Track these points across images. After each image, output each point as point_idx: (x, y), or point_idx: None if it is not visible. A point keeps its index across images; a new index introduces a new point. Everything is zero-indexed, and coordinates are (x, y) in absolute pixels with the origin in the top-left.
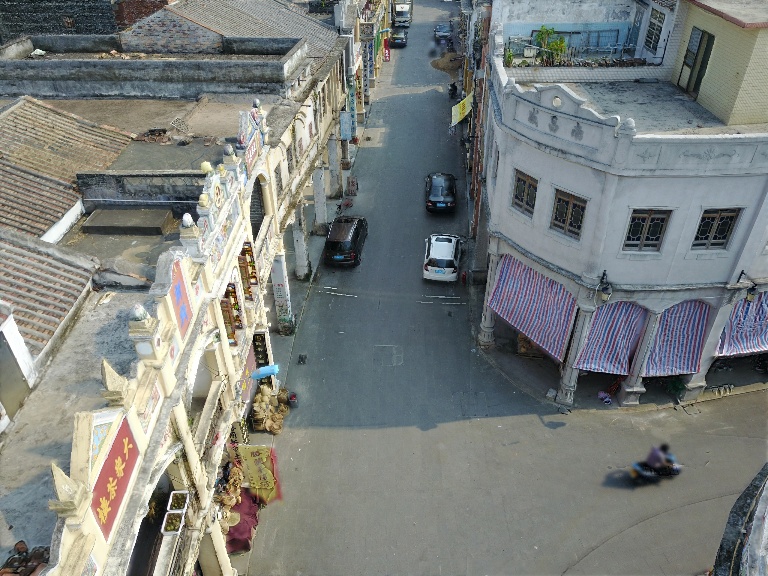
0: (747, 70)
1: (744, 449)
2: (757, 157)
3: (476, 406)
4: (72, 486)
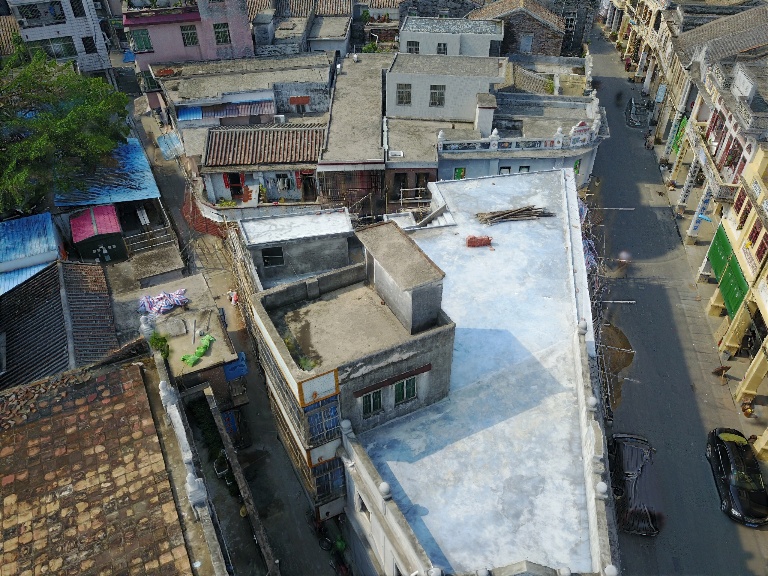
0: None
1: None
2: None
3: None
4: None
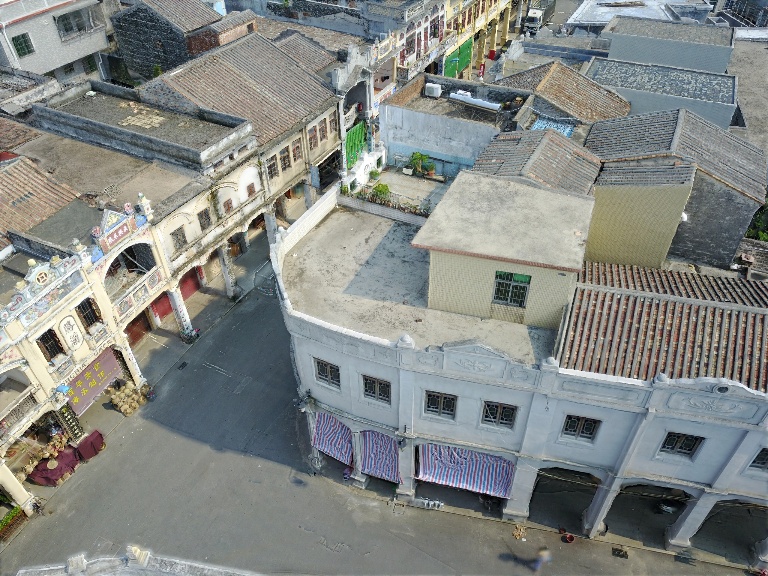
0: (431, 274)
1: (404, 555)
2: (377, 353)
3: (258, 445)
4: None
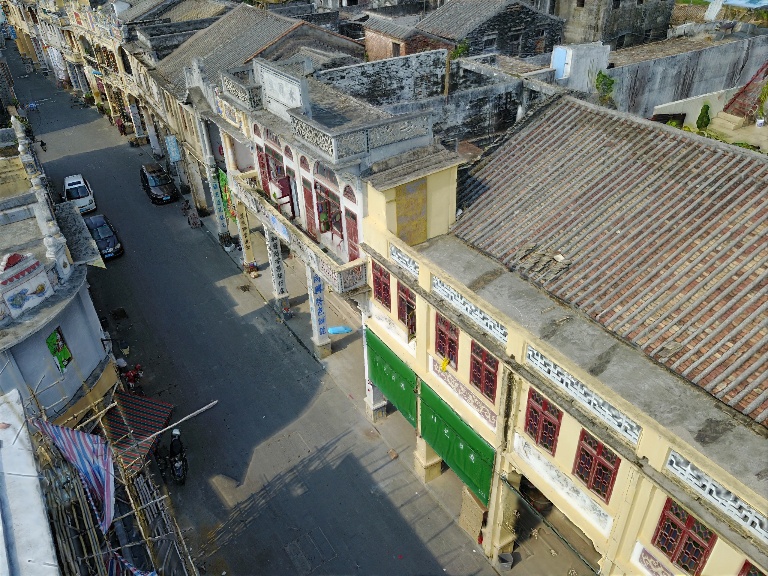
0: None
1: None
2: None
3: None
4: (70, 4)
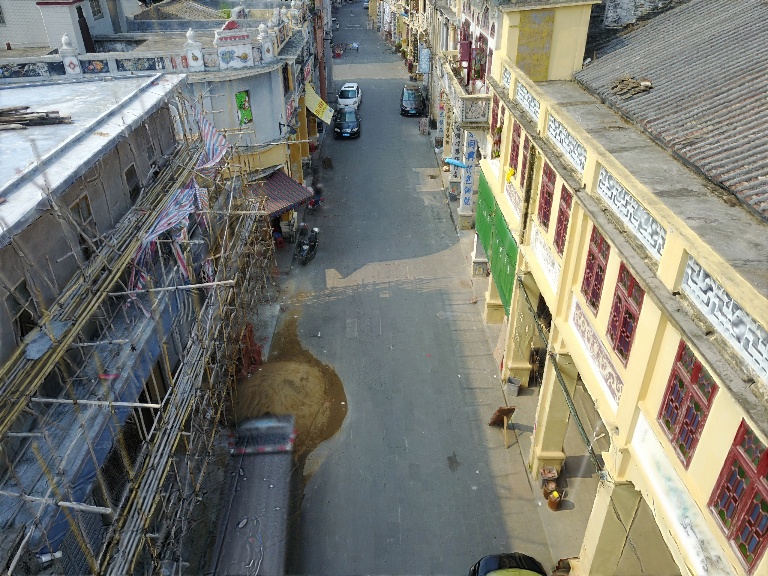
0: None
1: None
2: None
3: None
4: None
